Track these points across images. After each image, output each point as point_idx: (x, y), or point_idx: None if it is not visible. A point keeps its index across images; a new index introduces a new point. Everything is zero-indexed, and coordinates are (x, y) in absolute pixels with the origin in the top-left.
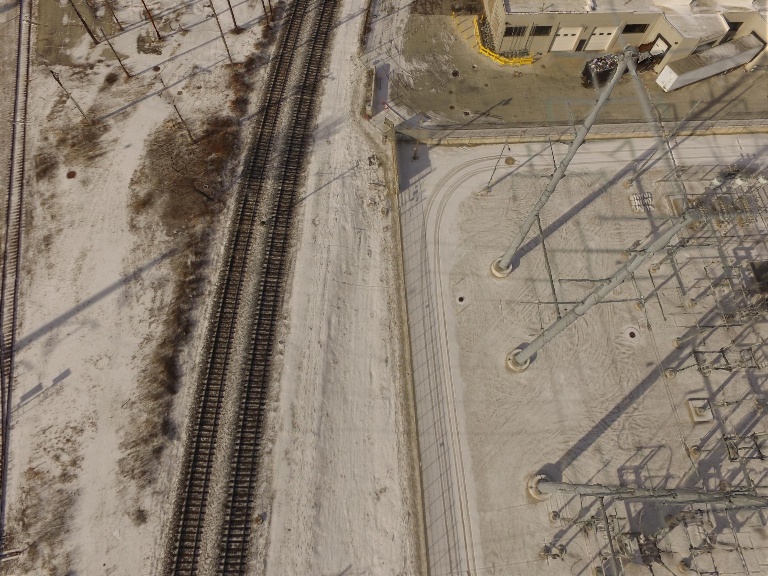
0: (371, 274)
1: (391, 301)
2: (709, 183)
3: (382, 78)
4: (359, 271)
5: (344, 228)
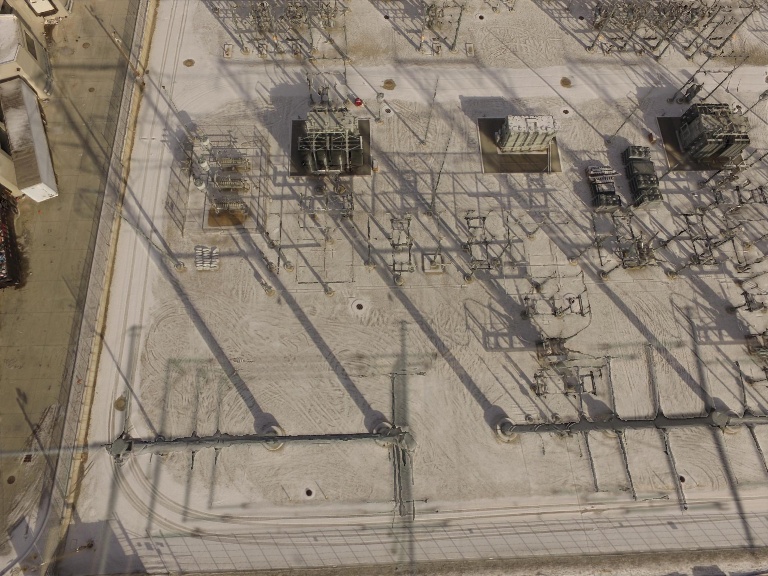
0: None
1: None
2: None
3: None
4: None
5: None
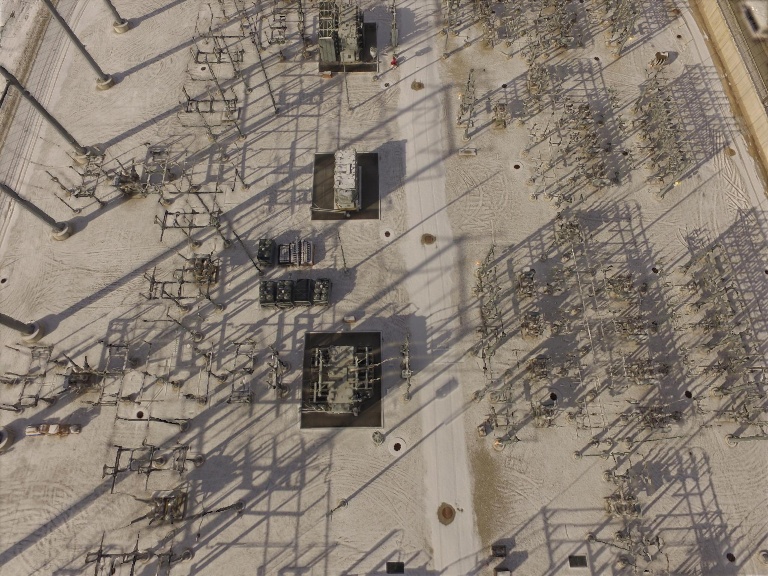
0: (22, 30)
1: (29, 47)
2: None
3: None
4: (13, 29)
5: (12, 1)
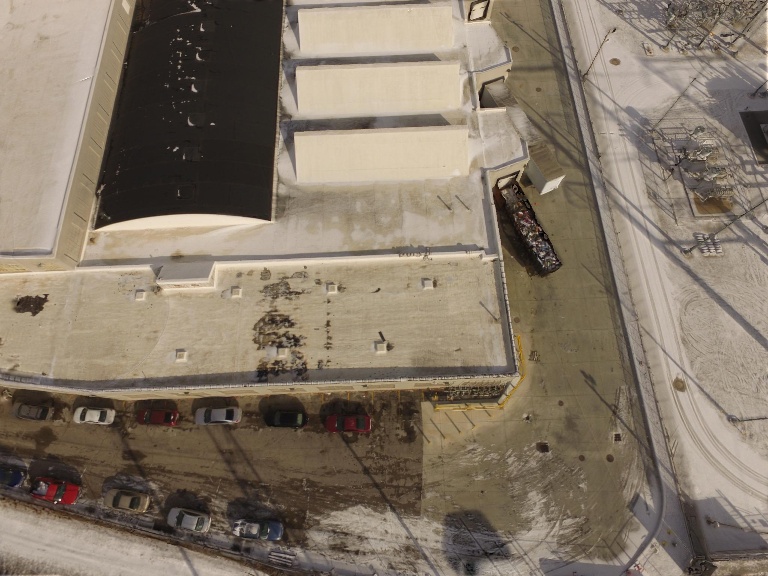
0: None
1: None
2: (707, 180)
3: (574, 574)
4: None
5: None
